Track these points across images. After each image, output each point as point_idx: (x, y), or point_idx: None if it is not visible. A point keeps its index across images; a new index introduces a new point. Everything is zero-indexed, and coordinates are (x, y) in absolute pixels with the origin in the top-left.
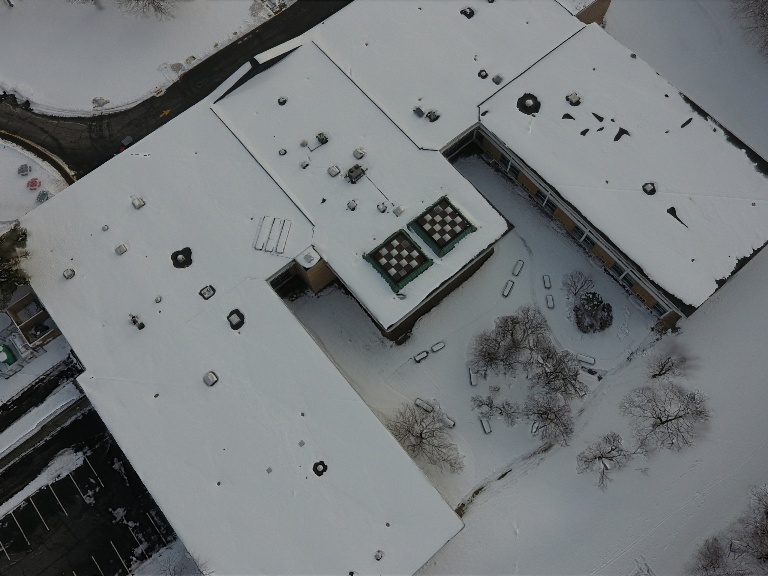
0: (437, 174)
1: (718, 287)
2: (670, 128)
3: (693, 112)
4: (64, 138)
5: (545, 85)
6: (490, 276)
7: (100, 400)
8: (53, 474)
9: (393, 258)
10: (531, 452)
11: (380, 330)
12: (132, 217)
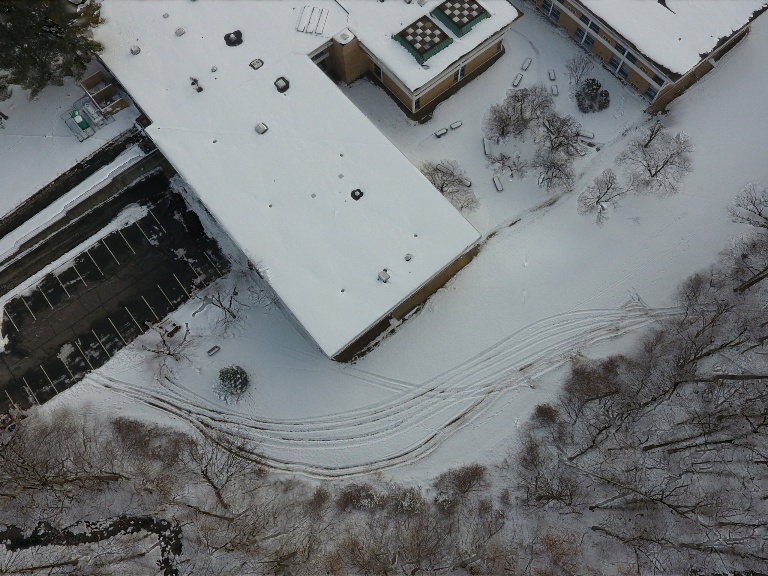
0: None
1: (701, 59)
2: None
3: None
4: None
5: None
6: (502, 71)
7: (166, 145)
8: (122, 221)
9: (418, 35)
10: (538, 206)
11: (405, 113)
12: (189, 7)
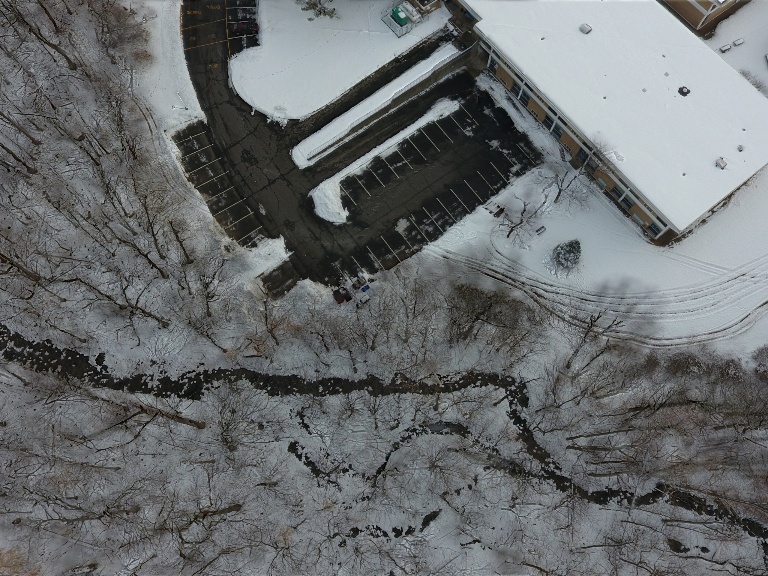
0: None
1: None
2: None
3: None
4: None
5: None
6: None
7: (498, 39)
8: (438, 112)
9: None
10: None
11: None
12: None
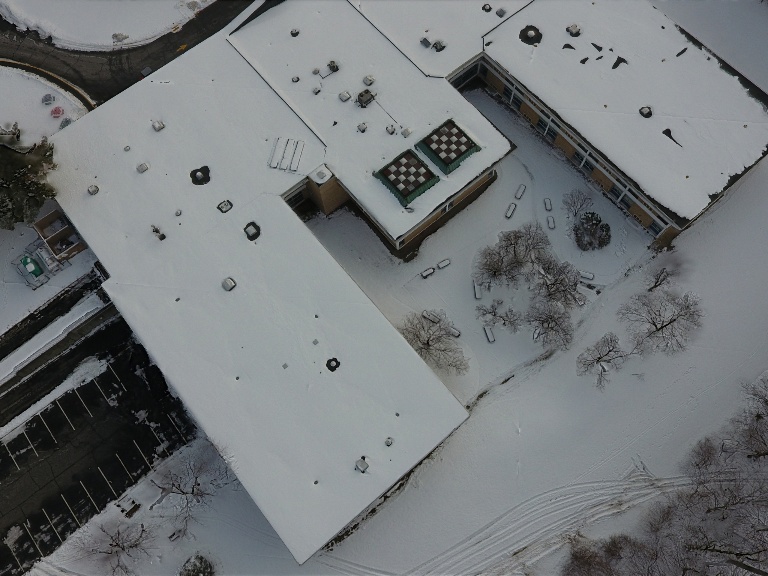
0: (443, 99)
1: (711, 201)
2: (666, 57)
3: (688, 42)
4: (85, 70)
5: (546, 18)
6: (494, 199)
7: (124, 304)
8: (78, 379)
9: (402, 174)
10: (533, 359)
11: (389, 249)
12: (152, 139)
